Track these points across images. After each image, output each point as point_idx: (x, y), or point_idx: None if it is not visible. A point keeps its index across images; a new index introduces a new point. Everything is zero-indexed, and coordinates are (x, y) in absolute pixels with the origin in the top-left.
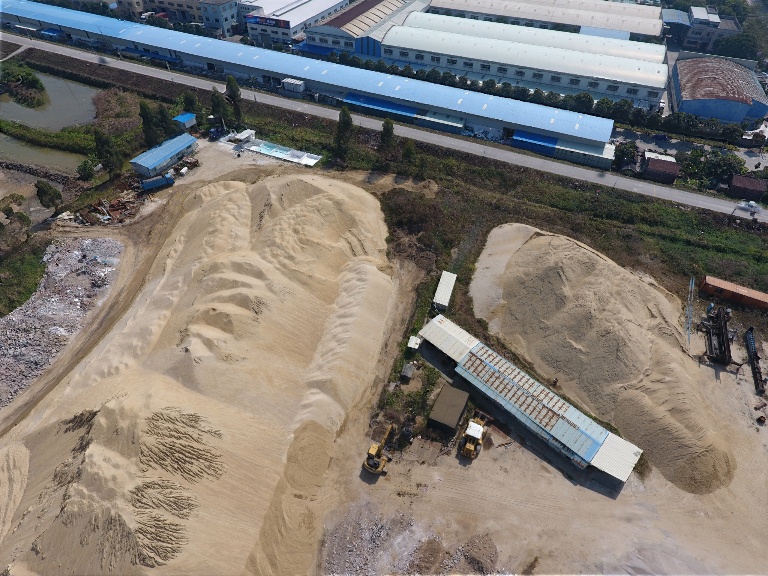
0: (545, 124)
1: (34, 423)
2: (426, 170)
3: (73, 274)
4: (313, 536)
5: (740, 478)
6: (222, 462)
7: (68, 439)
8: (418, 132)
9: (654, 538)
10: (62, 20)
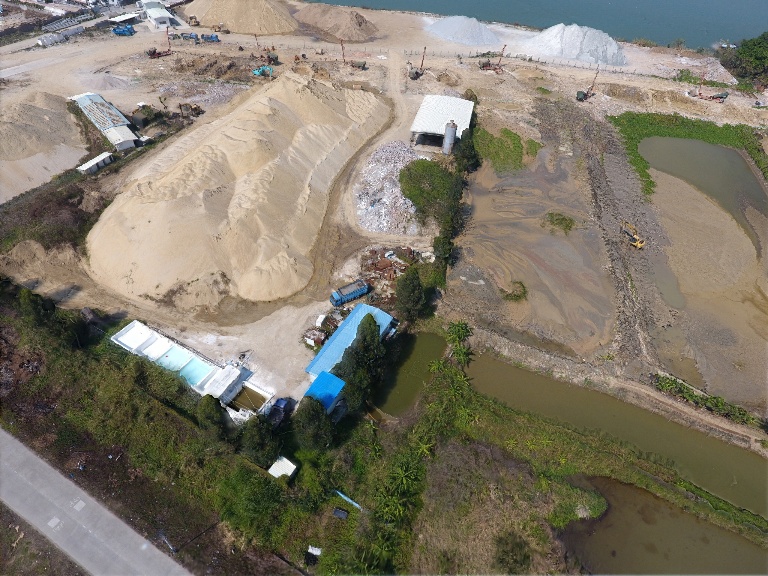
0: None
1: (355, 126)
2: None
3: None
4: None
5: None
6: None
7: None
8: None
9: (95, 91)
10: None
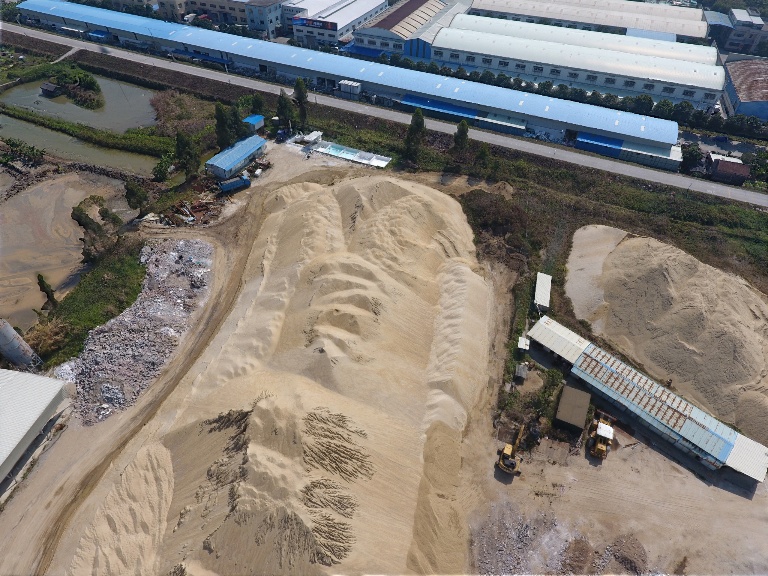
0: (610, 126)
1: (168, 423)
2: (499, 172)
3: (174, 275)
4: (462, 535)
5: None
6: (371, 462)
7: (215, 439)
8: (483, 134)
9: None
10: (110, 22)
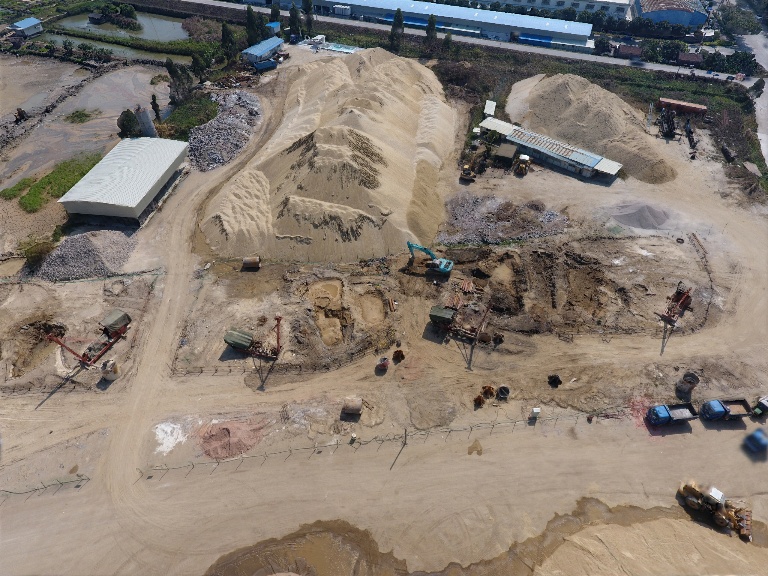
0: (542, 26)
1: None
2: None
3: (238, 105)
4: (440, 201)
5: (680, 178)
6: (386, 161)
7: (292, 155)
8: None
9: (631, 198)
10: None
